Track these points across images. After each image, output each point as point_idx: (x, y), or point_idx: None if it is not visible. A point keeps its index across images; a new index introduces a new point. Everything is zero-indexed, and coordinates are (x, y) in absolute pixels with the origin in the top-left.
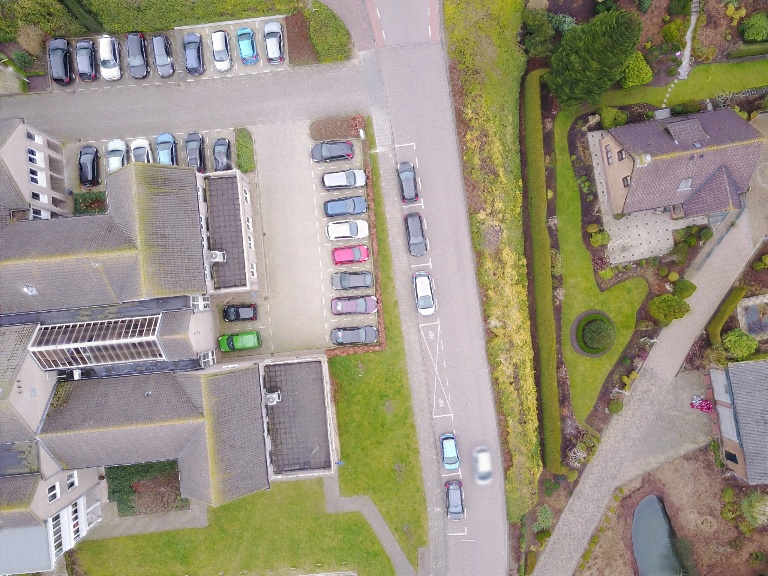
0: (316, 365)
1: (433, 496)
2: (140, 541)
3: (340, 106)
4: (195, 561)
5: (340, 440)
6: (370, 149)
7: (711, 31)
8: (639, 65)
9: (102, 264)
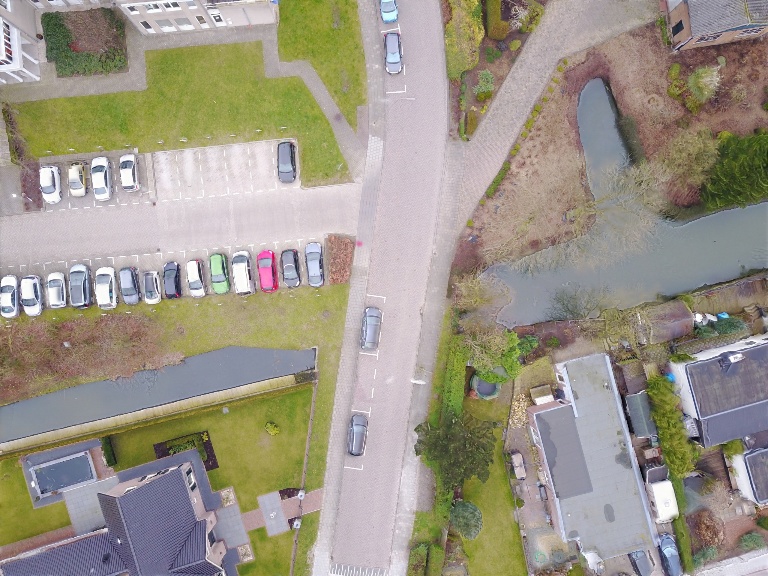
0: None
1: (372, 52)
2: (79, 103)
3: None
4: (135, 128)
5: (279, 3)
6: None
7: None
8: None
9: None
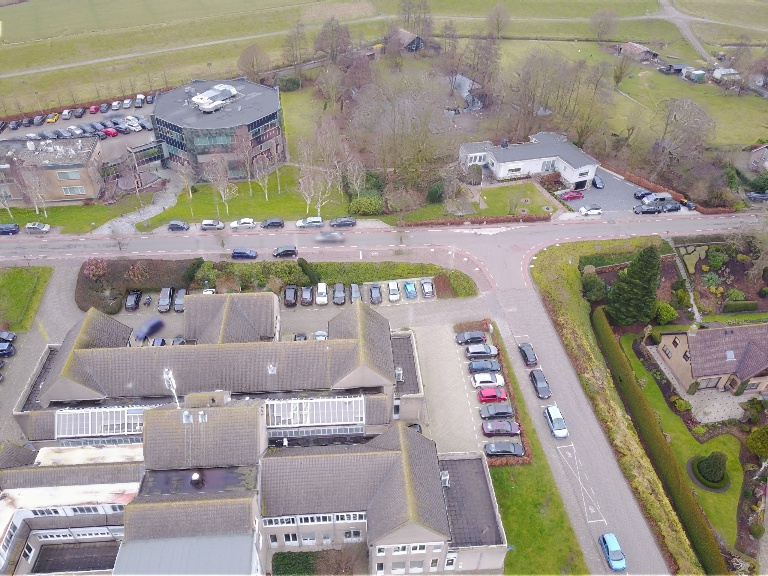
0: (477, 462)
1: None
2: None
3: (473, 317)
4: None
5: None
6: (497, 338)
7: (706, 300)
8: (666, 306)
9: (331, 349)
